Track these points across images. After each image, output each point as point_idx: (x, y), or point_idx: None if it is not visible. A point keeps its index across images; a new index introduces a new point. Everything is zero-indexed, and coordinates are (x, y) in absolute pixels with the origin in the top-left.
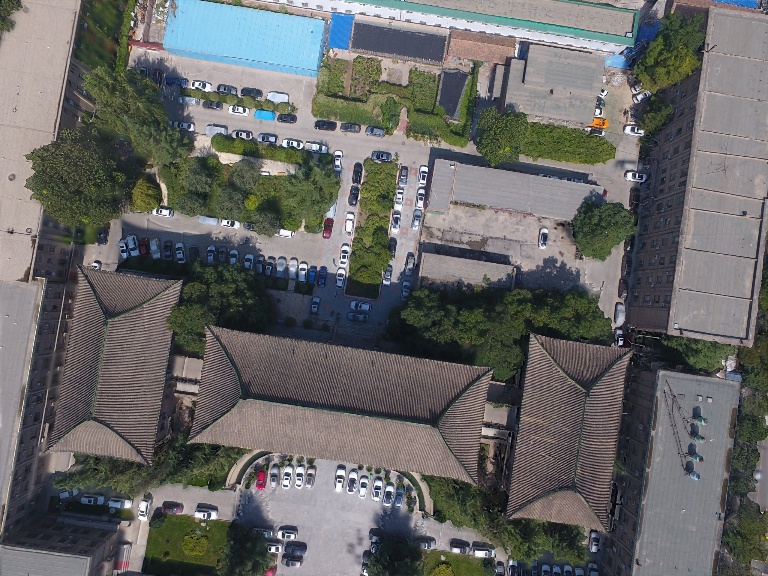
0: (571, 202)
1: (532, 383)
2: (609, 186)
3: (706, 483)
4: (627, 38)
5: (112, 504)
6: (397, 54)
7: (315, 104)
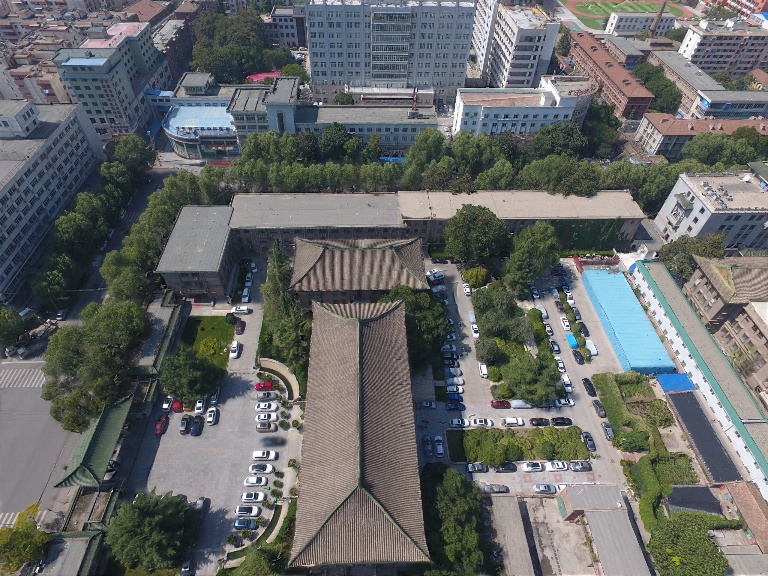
0: None
1: None
2: None
3: None
4: None
5: (246, 290)
6: (691, 435)
7: None
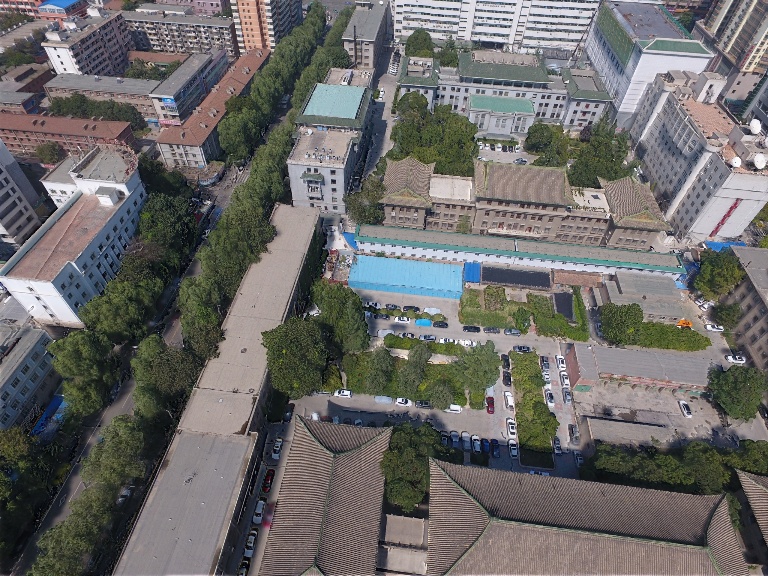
0: (699, 372)
1: (767, 524)
2: None
3: None
4: (680, 268)
5: None
6: (516, 284)
7: (462, 315)
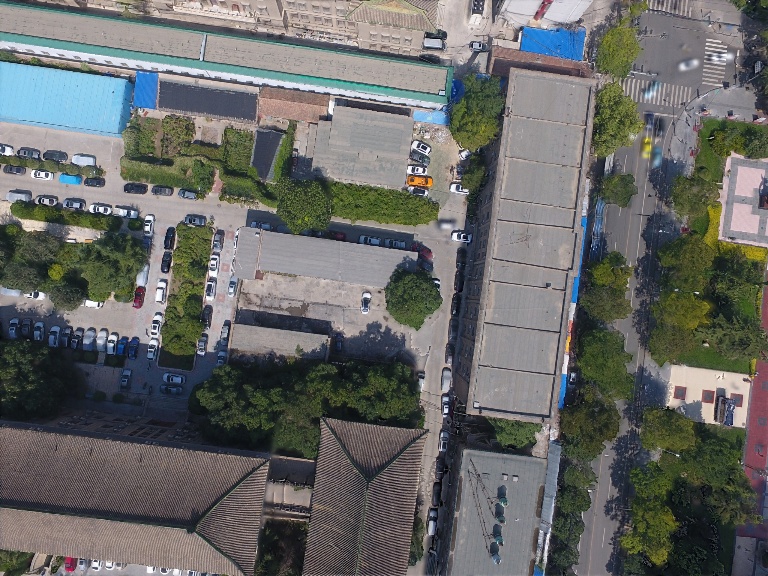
0: (383, 269)
1: (323, 469)
2: (435, 247)
3: (512, 565)
4: (439, 96)
5: None
6: (207, 113)
7: None
